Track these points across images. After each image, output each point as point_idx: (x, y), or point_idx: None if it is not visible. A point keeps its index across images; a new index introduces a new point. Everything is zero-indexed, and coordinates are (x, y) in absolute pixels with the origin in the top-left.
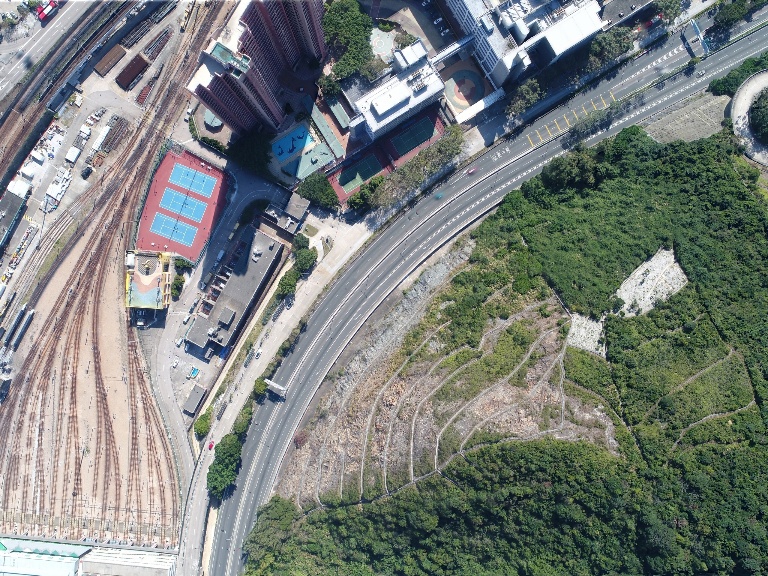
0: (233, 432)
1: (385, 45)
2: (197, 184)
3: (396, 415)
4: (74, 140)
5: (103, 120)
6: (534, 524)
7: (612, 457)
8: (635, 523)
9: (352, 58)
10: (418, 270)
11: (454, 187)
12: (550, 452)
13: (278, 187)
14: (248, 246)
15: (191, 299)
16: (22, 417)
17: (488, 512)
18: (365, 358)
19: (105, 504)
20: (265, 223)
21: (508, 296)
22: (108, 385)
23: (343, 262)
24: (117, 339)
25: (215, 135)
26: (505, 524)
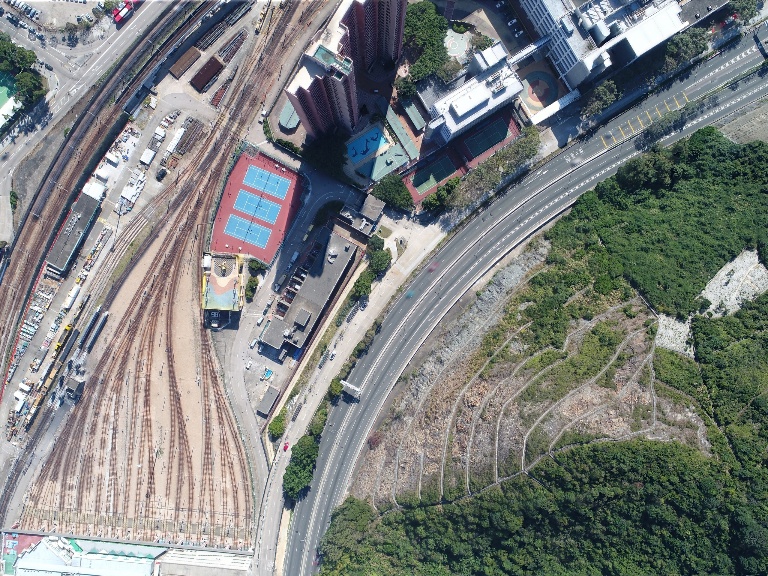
0: (308, 433)
1: (459, 47)
2: (271, 186)
3: (479, 416)
4: (149, 142)
5: (178, 122)
6: (622, 524)
7: (705, 457)
8: (729, 523)
9: (429, 60)
10: (491, 271)
11: (528, 188)
12: (643, 453)
13: (352, 189)
14: (324, 248)
15: (265, 301)
16: (96, 419)
17: (575, 513)
18: (441, 359)
19: (178, 505)
20: (339, 225)
21: (590, 297)
22: (182, 387)
23: (417, 263)
24: (191, 341)
25: (289, 137)
26: (591, 525)
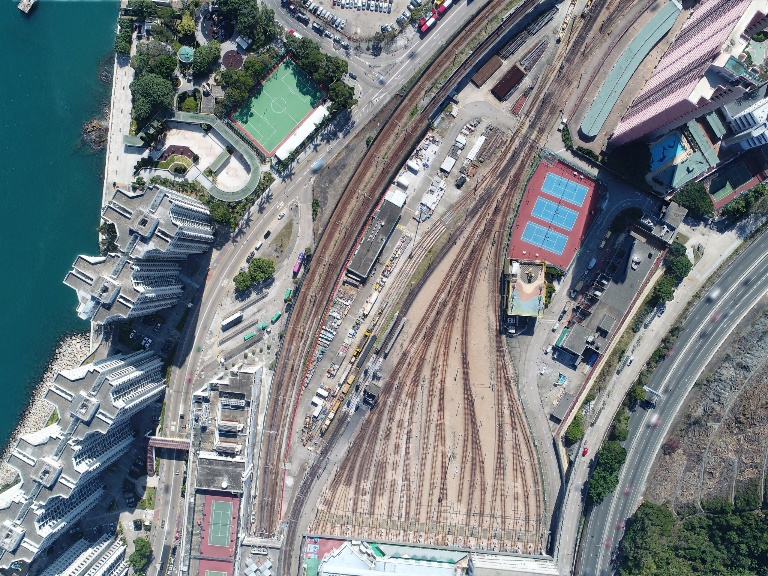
0: (607, 439)
1: (757, 55)
2: (569, 193)
3: None
4: (449, 150)
5: (478, 130)
6: None
7: None
8: None
9: None
10: None
11: None
12: None
13: (649, 196)
14: (627, 254)
15: (560, 307)
16: (390, 424)
17: None
18: (743, 365)
19: (470, 510)
20: (635, 231)
21: None
22: (476, 392)
23: (713, 270)
24: (486, 347)
25: (588, 145)
26: None
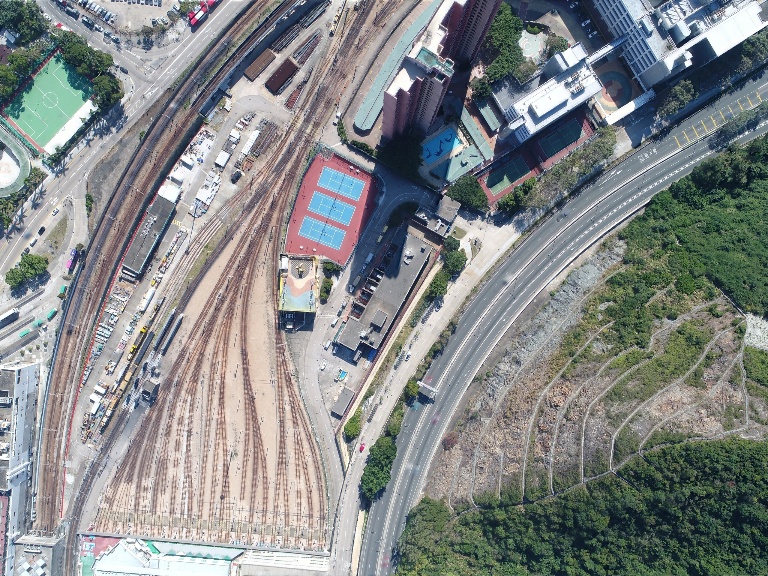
0: (384, 434)
1: (533, 47)
2: (345, 187)
3: (563, 416)
4: (223, 145)
5: (252, 124)
6: (712, 523)
7: None
8: None
9: (505, 61)
10: (565, 271)
11: (602, 188)
12: (737, 452)
13: (426, 190)
14: (400, 249)
15: (339, 302)
16: (170, 421)
17: (663, 512)
18: (517, 359)
19: (253, 507)
20: (413, 226)
21: (673, 296)
22: (256, 388)
23: (491, 264)
24: (265, 342)
25: (363, 138)
26: (679, 524)
